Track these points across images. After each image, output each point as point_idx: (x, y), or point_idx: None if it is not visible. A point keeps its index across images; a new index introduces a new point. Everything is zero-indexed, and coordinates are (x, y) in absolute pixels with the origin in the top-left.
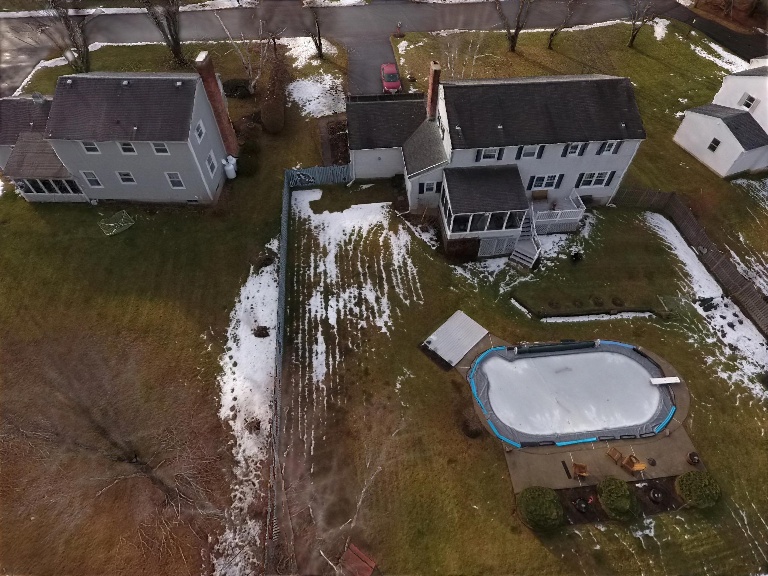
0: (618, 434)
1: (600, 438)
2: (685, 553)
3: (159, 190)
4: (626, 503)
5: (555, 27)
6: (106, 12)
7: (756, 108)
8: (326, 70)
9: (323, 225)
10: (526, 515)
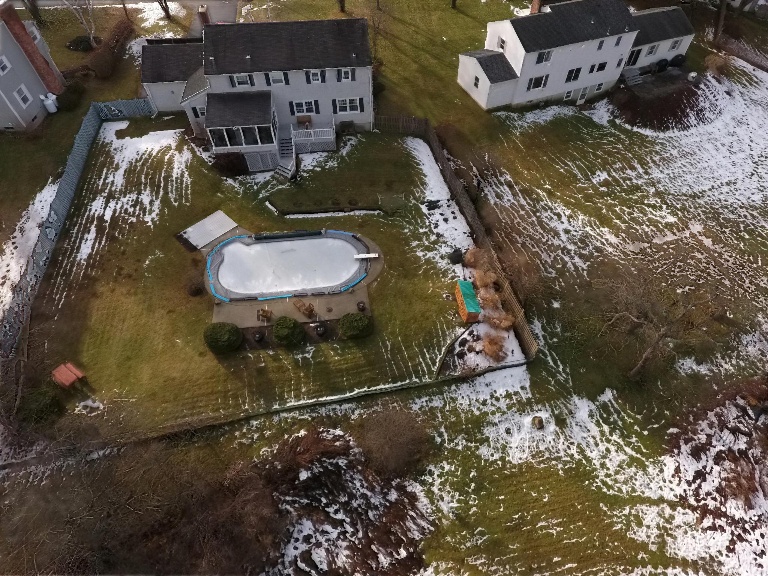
0: (311, 292)
1: (295, 295)
2: (331, 368)
3: None
4: (286, 331)
5: None
6: None
7: (506, 49)
8: (170, 29)
9: (122, 147)
10: (204, 339)
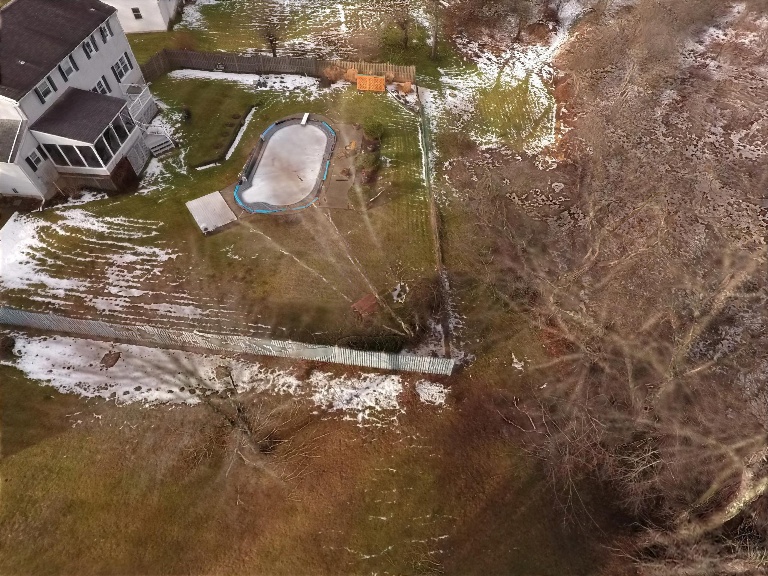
0: (329, 151)
1: (329, 159)
2: (402, 152)
3: None
4: (372, 156)
5: None
6: None
7: None
8: None
9: None
10: (364, 200)
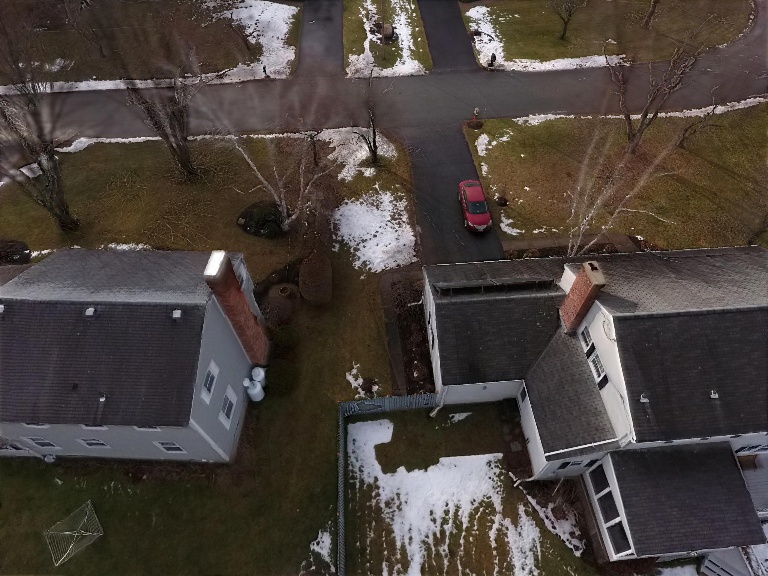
0: None
1: None
2: None
3: (147, 450)
4: None
5: (679, 109)
6: (99, 87)
7: None
8: (383, 185)
9: (398, 499)
10: None
